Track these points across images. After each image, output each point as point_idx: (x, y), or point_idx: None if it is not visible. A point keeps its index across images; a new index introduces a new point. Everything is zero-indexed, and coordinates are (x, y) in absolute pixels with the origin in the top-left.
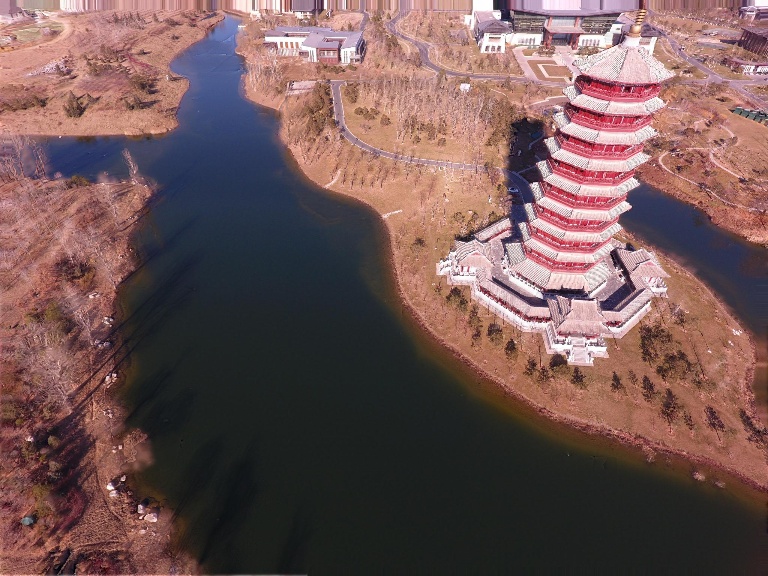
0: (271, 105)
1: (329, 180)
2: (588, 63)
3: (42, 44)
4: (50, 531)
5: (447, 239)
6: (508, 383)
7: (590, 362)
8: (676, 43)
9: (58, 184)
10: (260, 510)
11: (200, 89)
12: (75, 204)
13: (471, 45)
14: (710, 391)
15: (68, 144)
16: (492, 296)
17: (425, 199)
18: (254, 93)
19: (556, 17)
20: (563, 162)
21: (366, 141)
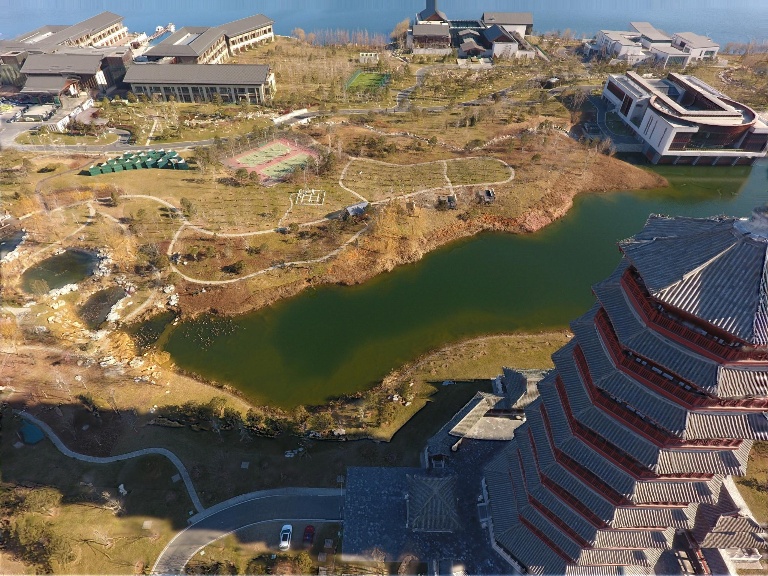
0: None
1: None
2: None
3: None
4: None
5: None
6: None
7: None
8: None
9: None
10: None
11: None
12: None
13: None
14: None
15: None
16: None
17: None
18: None
19: None
20: None
21: None
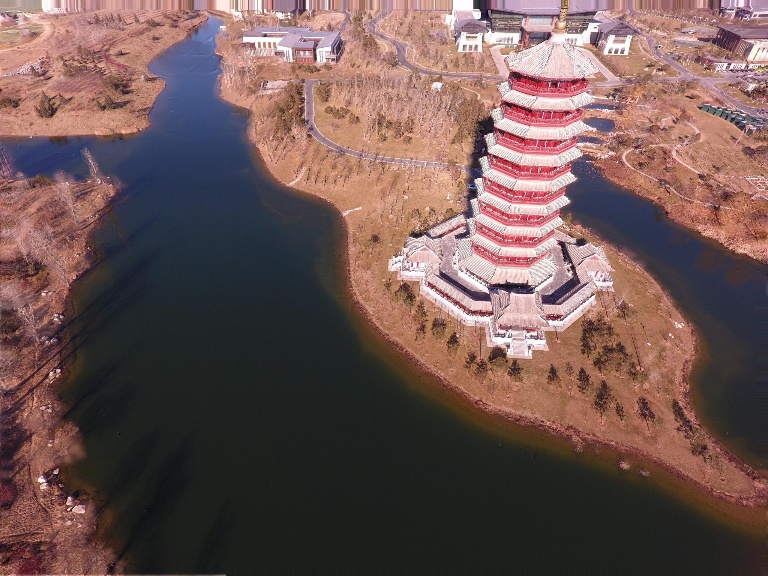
0: (244, 105)
1: (293, 178)
2: (518, 59)
3: (20, 45)
4: None
5: (402, 235)
6: (447, 376)
7: (529, 355)
8: (653, 41)
9: (21, 184)
10: (188, 501)
11: (176, 89)
12: (36, 203)
13: (449, 44)
14: (642, 382)
15: (38, 144)
16: (439, 291)
17: (385, 196)
18: (229, 93)
19: (533, 16)
20: (500, 157)
21: (333, 140)
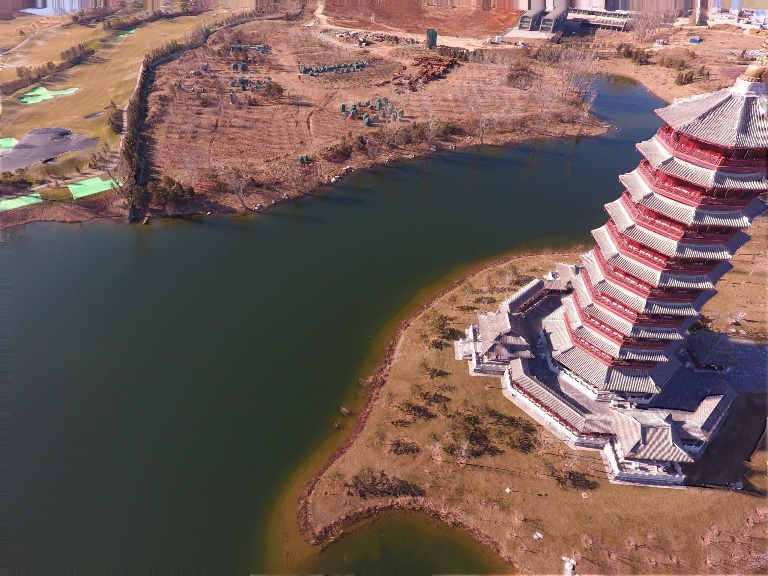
0: None
1: None
2: None
3: None
4: (327, 156)
5: None
6: None
7: (460, 357)
8: None
9: None
10: (336, 208)
11: None
12: None
13: None
14: None
15: (642, 96)
16: None
17: None
18: None
19: None
20: None
21: None
